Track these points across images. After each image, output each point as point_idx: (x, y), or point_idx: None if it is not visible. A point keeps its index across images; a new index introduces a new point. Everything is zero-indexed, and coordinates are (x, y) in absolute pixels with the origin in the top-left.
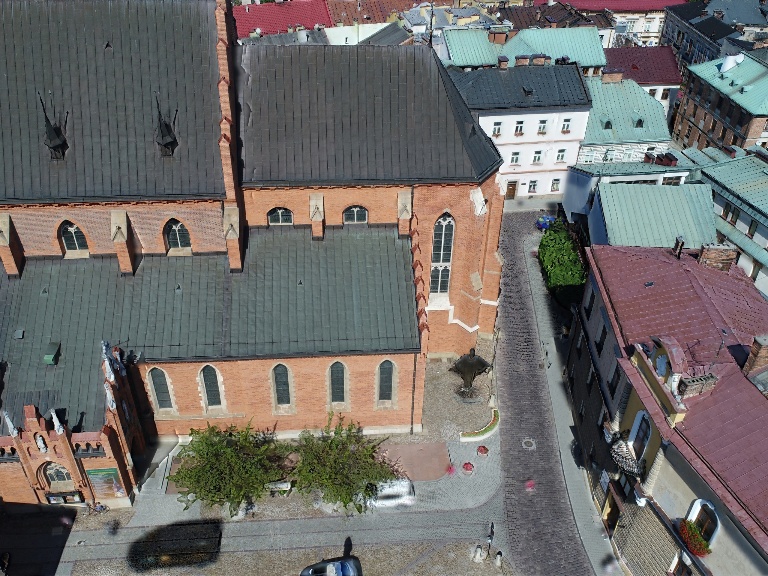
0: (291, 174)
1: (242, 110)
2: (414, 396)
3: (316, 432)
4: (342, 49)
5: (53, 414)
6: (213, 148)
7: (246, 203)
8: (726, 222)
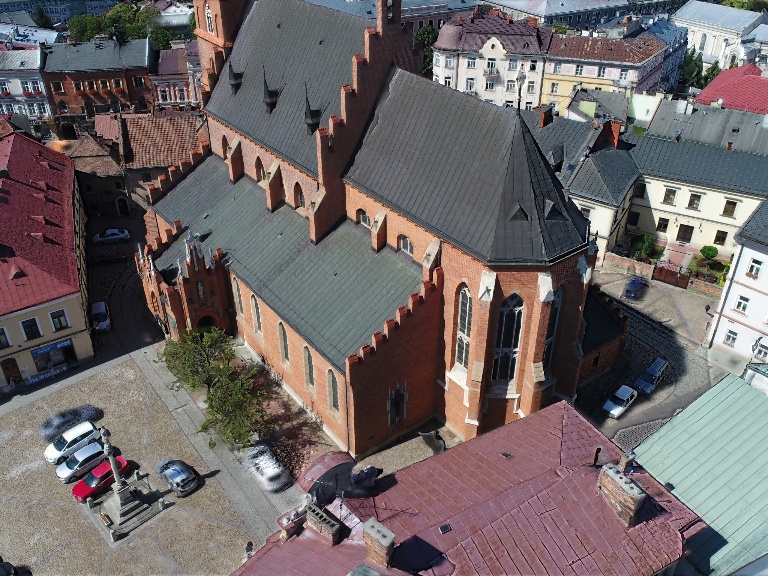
0: (374, 185)
1: (374, 120)
2: (348, 421)
3: (301, 401)
4: (454, 93)
5: (150, 259)
6: None
7: (347, 195)
8: None
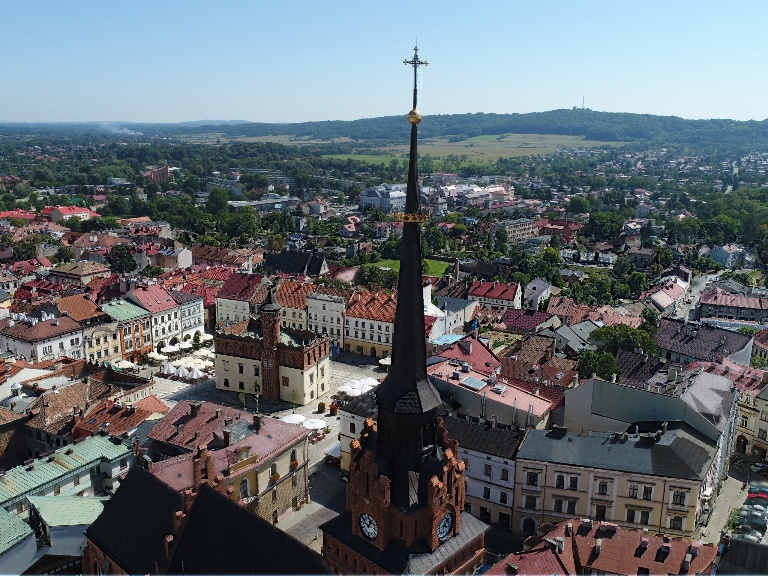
0: None
1: None
2: None
3: None
4: None
5: None
6: None
7: None
8: (25, 512)
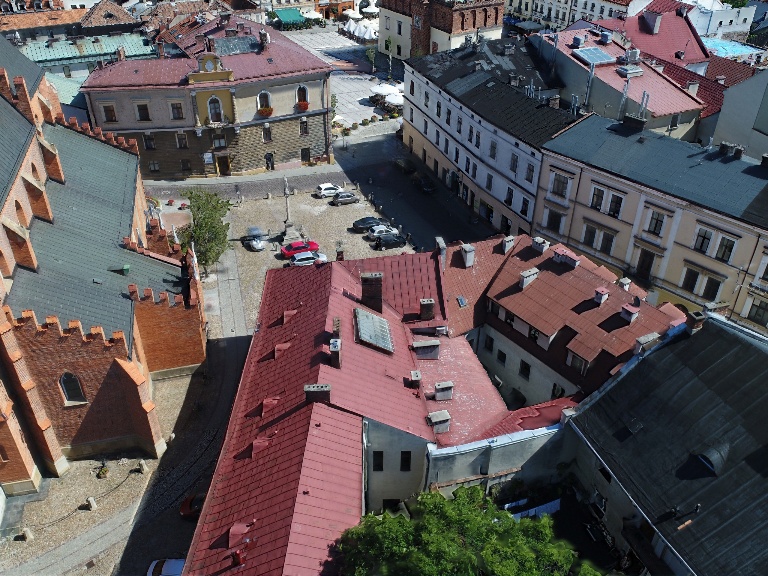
0: None
1: None
2: None
3: None
4: None
5: None
6: (1, 101)
7: None
8: None
